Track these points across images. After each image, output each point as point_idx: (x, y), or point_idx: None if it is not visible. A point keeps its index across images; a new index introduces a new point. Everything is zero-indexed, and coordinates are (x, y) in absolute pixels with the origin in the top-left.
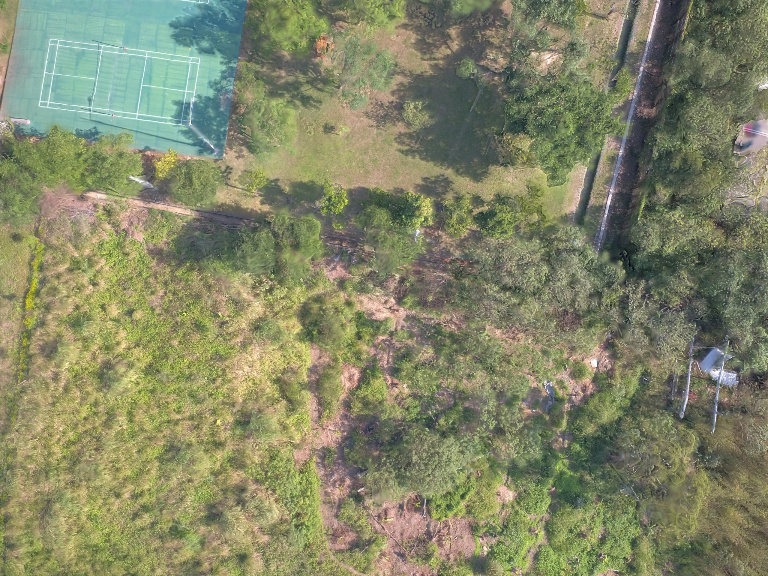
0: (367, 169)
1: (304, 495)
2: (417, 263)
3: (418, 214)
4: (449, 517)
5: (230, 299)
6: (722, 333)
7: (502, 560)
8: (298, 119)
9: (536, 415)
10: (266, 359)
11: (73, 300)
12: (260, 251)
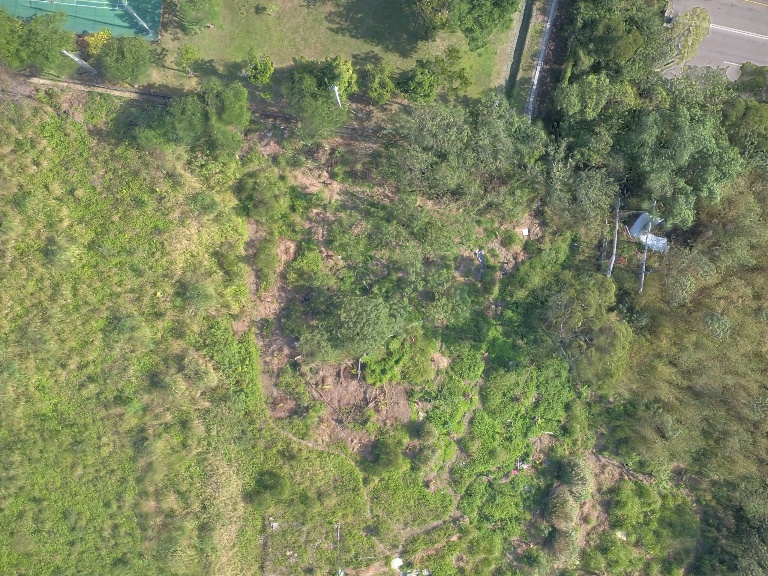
0: (299, 47)
1: (243, 364)
2: (349, 137)
3: (337, 73)
4: (384, 382)
5: (168, 176)
6: (648, 193)
7: (437, 424)
8: (231, 1)
9: (468, 283)
10: (203, 233)
11: (17, 180)
12: (187, 115)
